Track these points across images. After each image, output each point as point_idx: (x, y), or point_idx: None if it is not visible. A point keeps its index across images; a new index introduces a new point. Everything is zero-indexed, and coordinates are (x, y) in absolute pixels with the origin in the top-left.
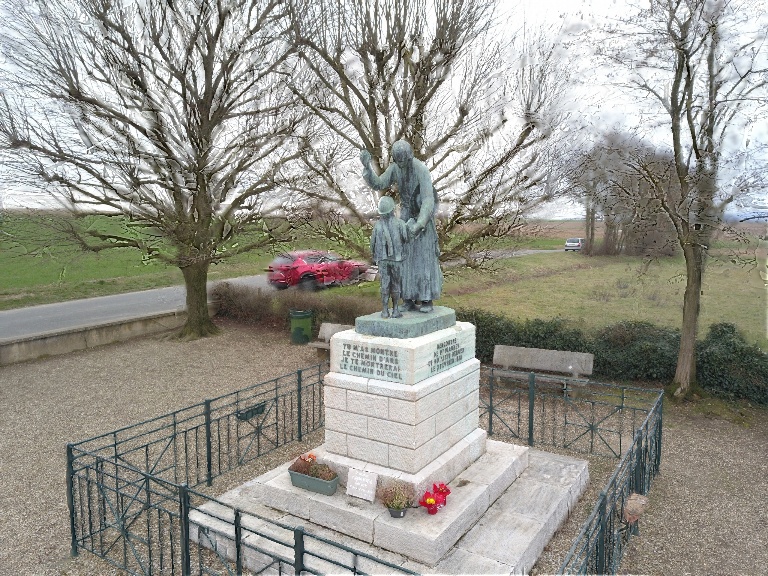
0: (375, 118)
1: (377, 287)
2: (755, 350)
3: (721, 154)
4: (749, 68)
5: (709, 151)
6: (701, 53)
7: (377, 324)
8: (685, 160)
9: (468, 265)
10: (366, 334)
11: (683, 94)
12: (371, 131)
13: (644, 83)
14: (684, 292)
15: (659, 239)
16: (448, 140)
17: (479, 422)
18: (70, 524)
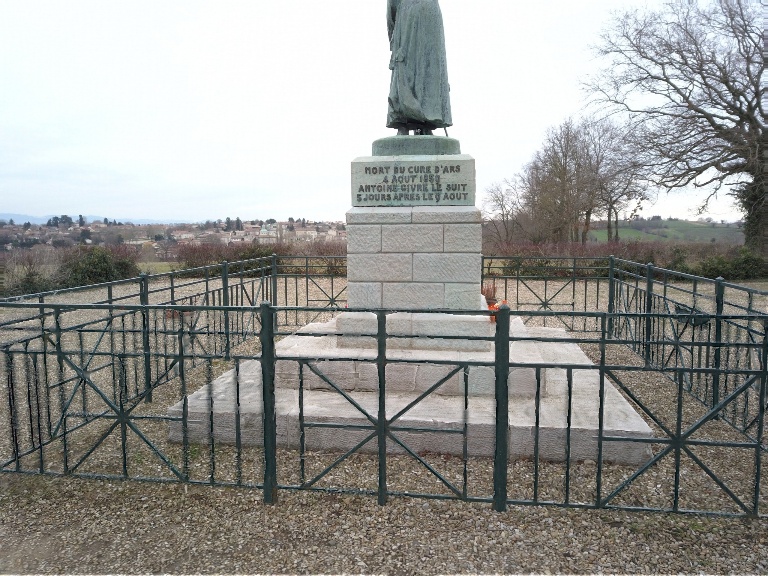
0: None
1: None
2: None
3: None
4: None
5: None
6: None
7: None
8: None
9: None
10: None
11: None
12: None
13: None
14: None
15: None
16: None
17: (459, 571)
18: (671, 349)
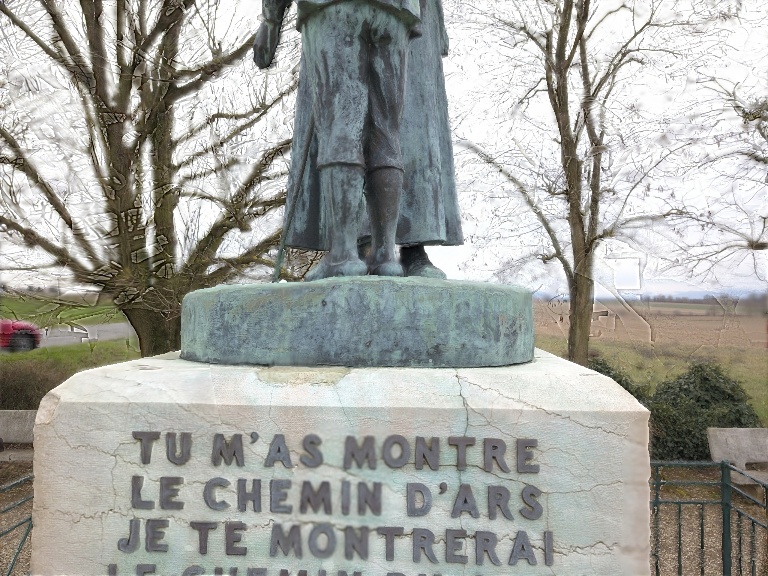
0: (98, 4)
1: (76, 342)
2: (649, 389)
3: (643, 116)
4: (647, 20)
5: (589, 131)
6: (556, 20)
7: (349, 299)
8: (574, 135)
9: (282, 276)
10: (276, 363)
11: (575, 43)
12: (86, 35)
13: (522, 25)
14: (567, 317)
15: (490, 262)
16: (247, 54)
17: None
18: None
